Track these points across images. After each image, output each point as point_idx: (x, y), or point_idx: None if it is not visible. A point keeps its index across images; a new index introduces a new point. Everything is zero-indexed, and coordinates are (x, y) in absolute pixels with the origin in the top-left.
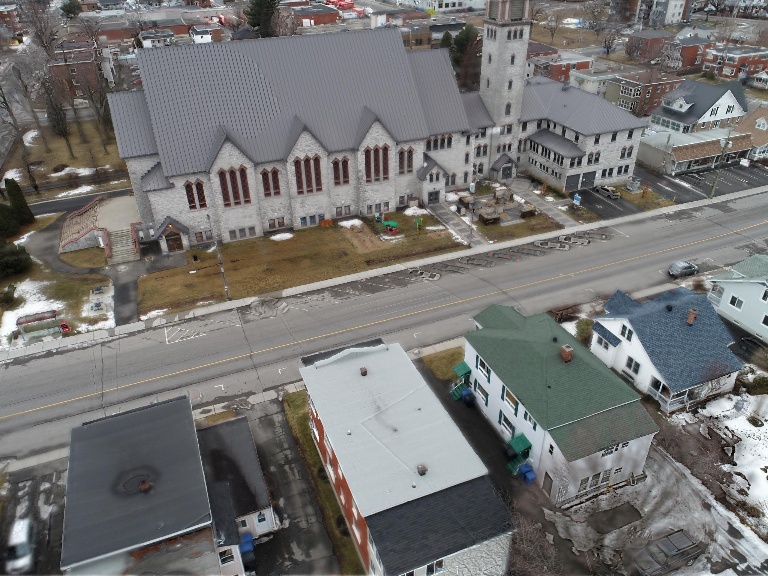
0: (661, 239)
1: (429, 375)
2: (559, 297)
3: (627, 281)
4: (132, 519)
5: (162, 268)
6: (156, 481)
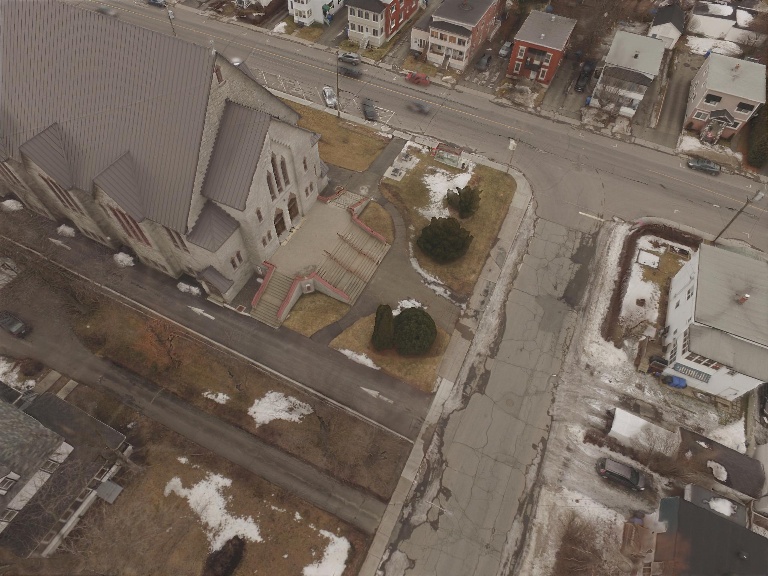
0: (117, 16)
1: (324, 34)
2: (221, 27)
3: (184, 16)
4: (473, 0)
5: (342, 171)
6: (460, 5)
